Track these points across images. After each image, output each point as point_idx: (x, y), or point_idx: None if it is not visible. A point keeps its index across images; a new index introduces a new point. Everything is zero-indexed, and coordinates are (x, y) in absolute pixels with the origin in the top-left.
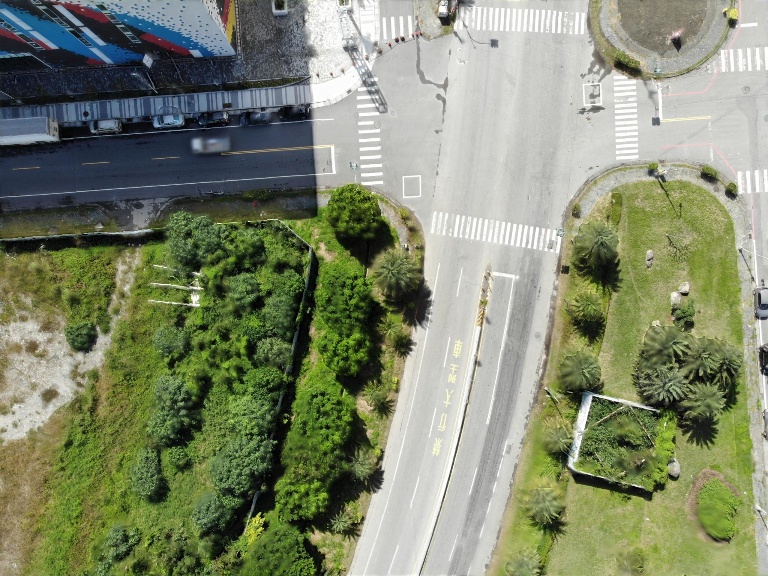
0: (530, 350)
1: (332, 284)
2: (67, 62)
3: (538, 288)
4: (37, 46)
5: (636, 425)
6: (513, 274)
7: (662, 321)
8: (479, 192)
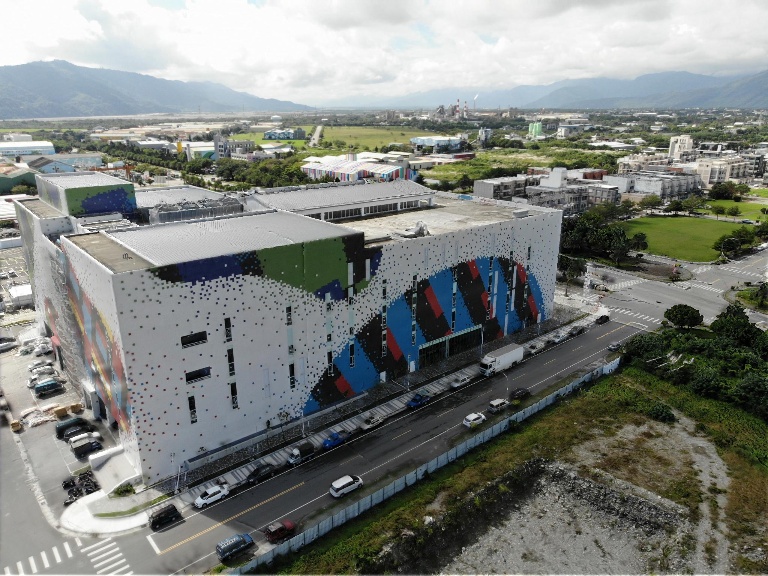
0: None
1: None
2: (490, 337)
3: None
4: (488, 315)
5: None
6: (762, 321)
7: None
8: None
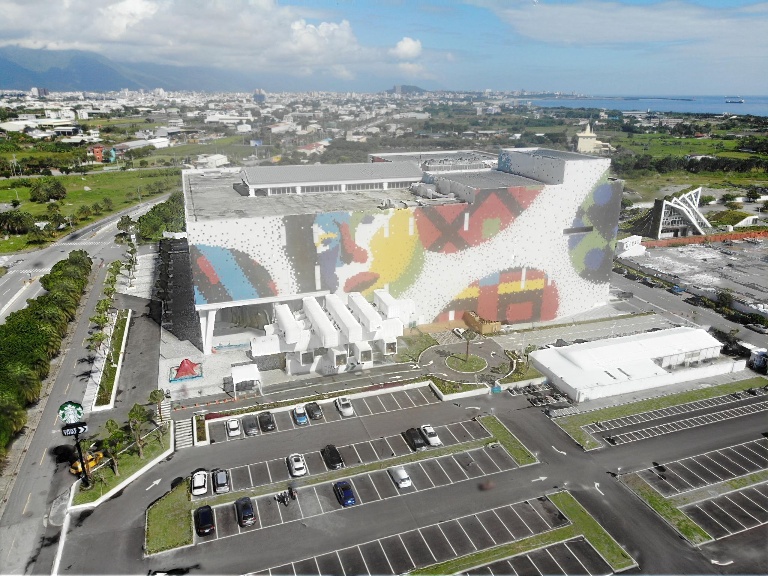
0: (77, 233)
1: (153, 218)
2: None
3: None
4: None
5: (41, 220)
6: None
7: None
8: None
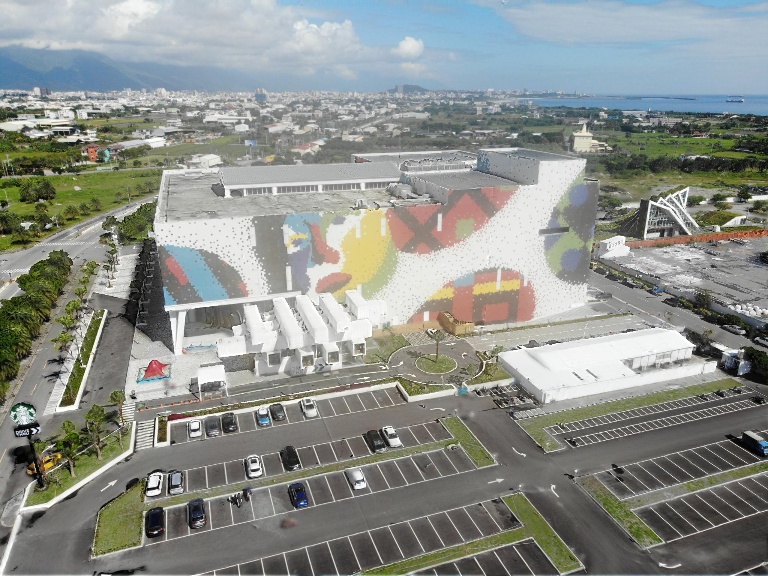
0: (63, 233)
1: (138, 218)
2: None
3: (53, 239)
4: None
5: (28, 220)
6: None
7: (1, 237)
8: (69, 247)
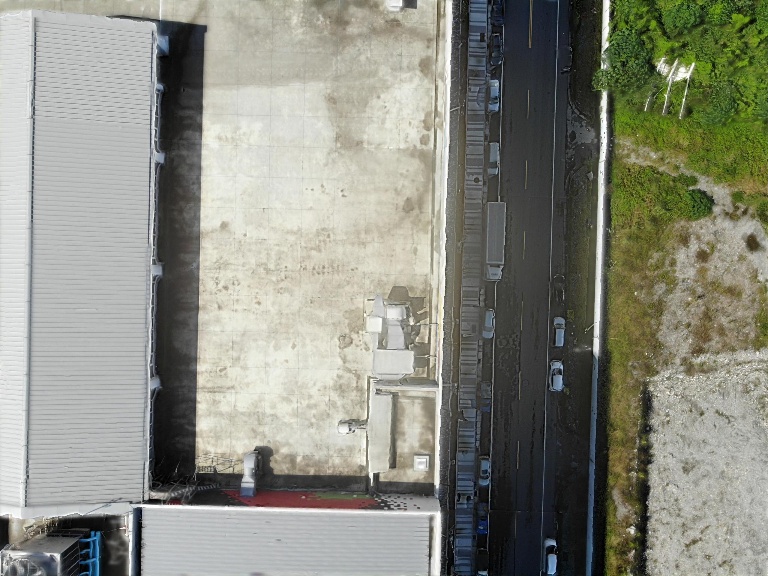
0: None
1: None
2: None
3: None
4: None
5: None
6: None
7: None
8: None
